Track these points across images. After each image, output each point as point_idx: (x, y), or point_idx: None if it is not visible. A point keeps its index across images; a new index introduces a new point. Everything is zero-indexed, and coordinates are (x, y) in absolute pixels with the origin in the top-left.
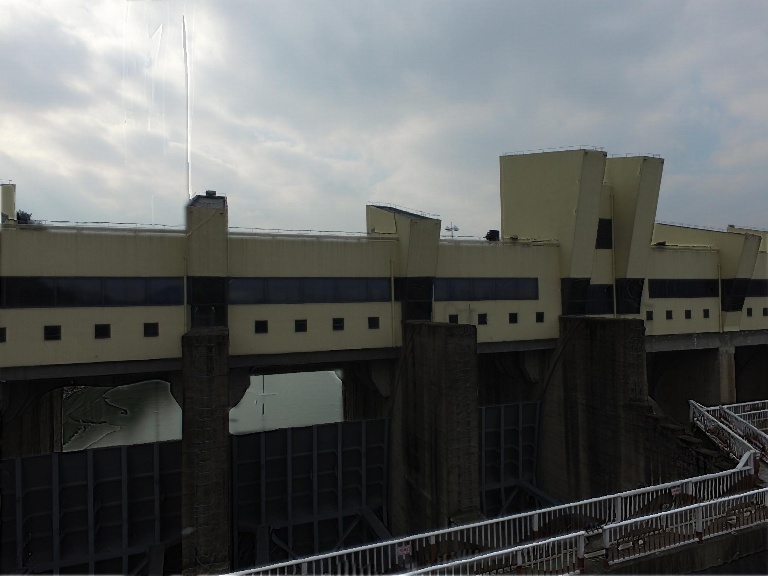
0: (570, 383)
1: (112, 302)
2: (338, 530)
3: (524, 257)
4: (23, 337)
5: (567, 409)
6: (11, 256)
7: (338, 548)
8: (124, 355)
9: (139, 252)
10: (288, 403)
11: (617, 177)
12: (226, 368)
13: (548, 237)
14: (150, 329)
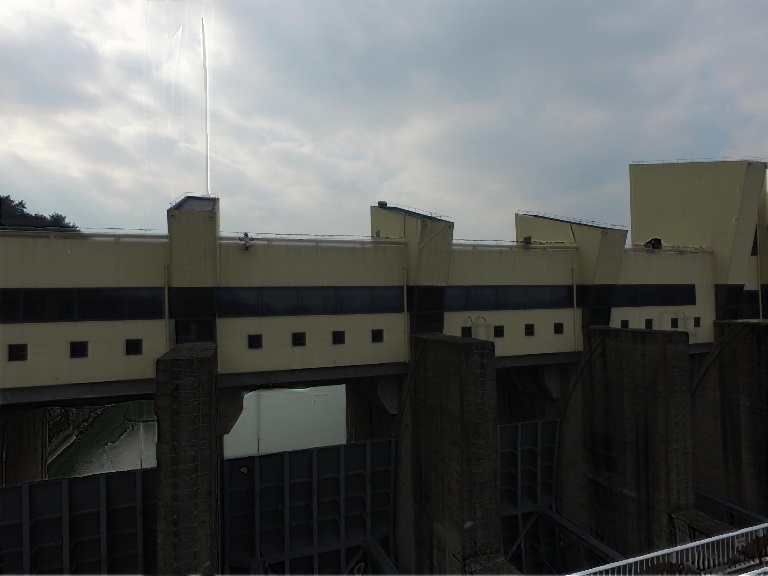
0: (729, 386)
1: (345, 310)
2: (518, 526)
3: (683, 264)
4: (275, 343)
5: (725, 411)
6: (265, 268)
7: (519, 543)
8: (356, 360)
9: (366, 263)
10: (344, 403)
11: (763, 186)
12: None
13: (697, 244)
14: (376, 335)
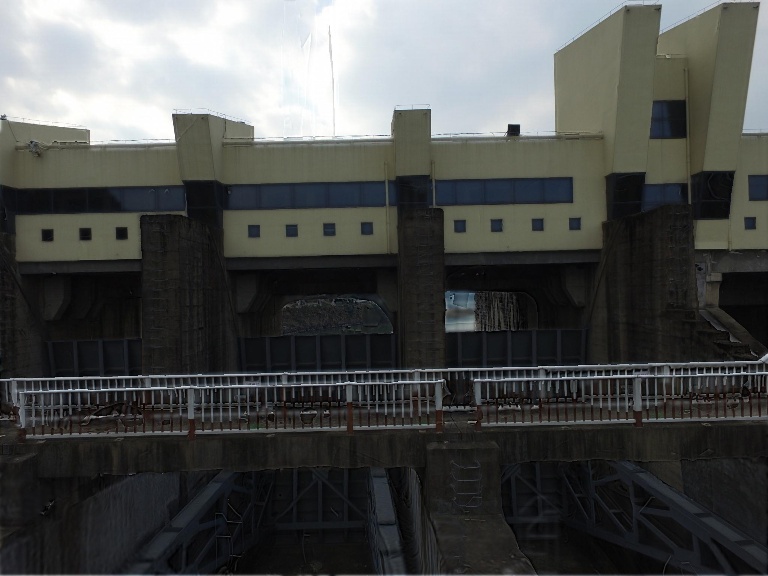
0: (612, 300)
1: (129, 209)
2: None
3: (553, 153)
4: (65, 237)
5: (610, 332)
6: (56, 171)
7: None
8: (138, 254)
9: (149, 164)
10: None
11: (692, 44)
12: (177, 245)
13: (594, 131)
14: None
